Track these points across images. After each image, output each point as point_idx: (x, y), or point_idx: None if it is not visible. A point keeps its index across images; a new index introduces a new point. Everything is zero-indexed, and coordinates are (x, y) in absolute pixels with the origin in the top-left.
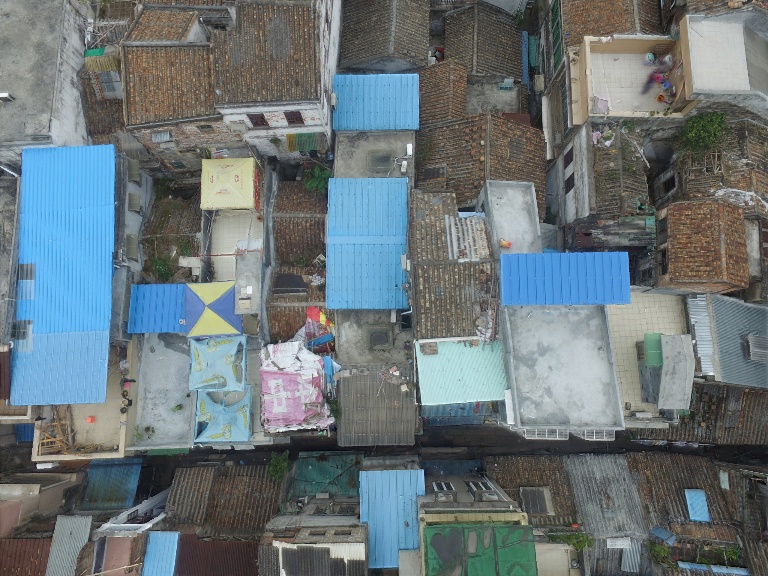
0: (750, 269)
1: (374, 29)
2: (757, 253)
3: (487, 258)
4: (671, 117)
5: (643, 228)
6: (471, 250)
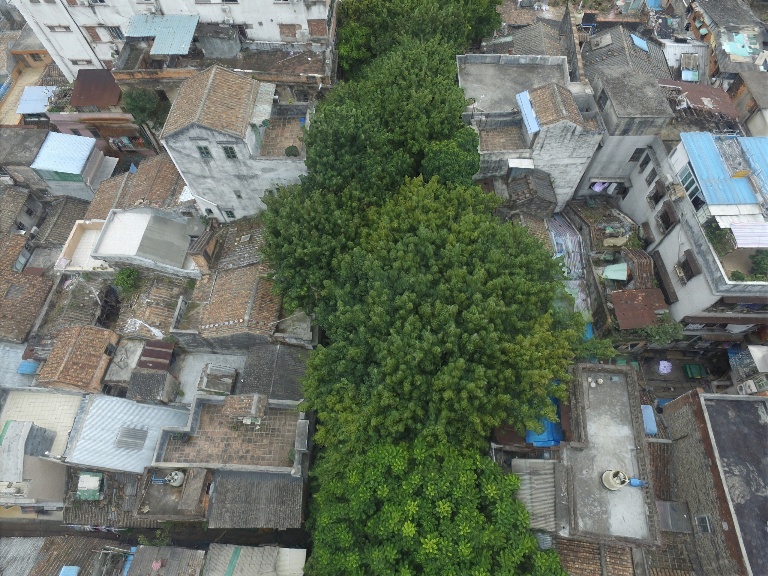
0: (125, 375)
1: None
2: (135, 364)
3: None
4: (108, 271)
5: None
6: None
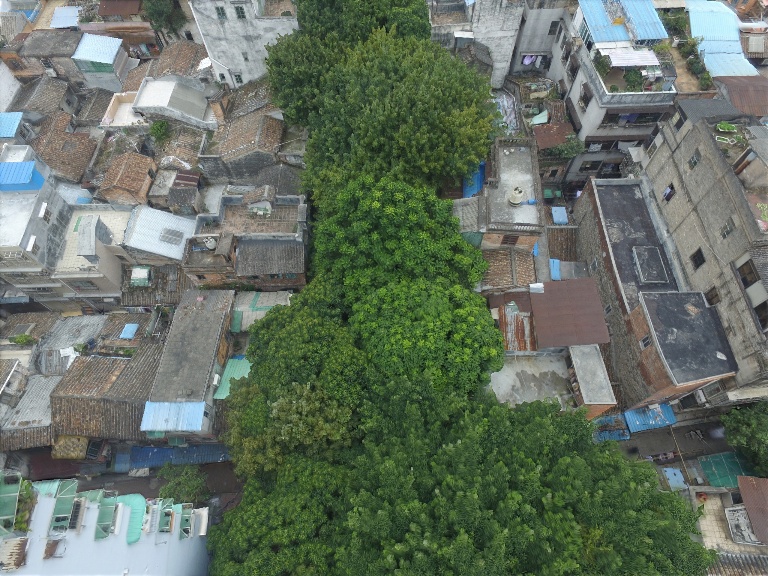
0: (164, 192)
1: (25, 99)
2: (171, 185)
3: None
4: (144, 125)
5: None
6: None
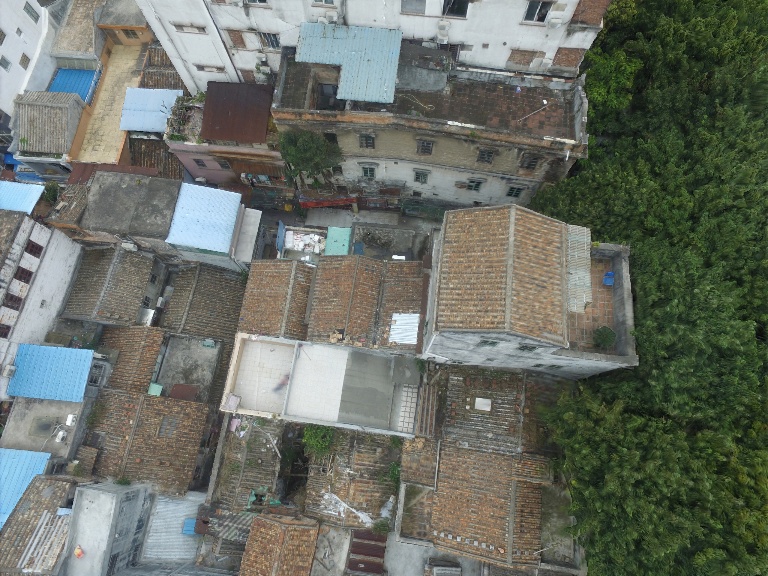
0: None
1: (92, 289)
2: (343, 564)
3: (49, 570)
4: None
5: (249, 525)
6: (40, 559)
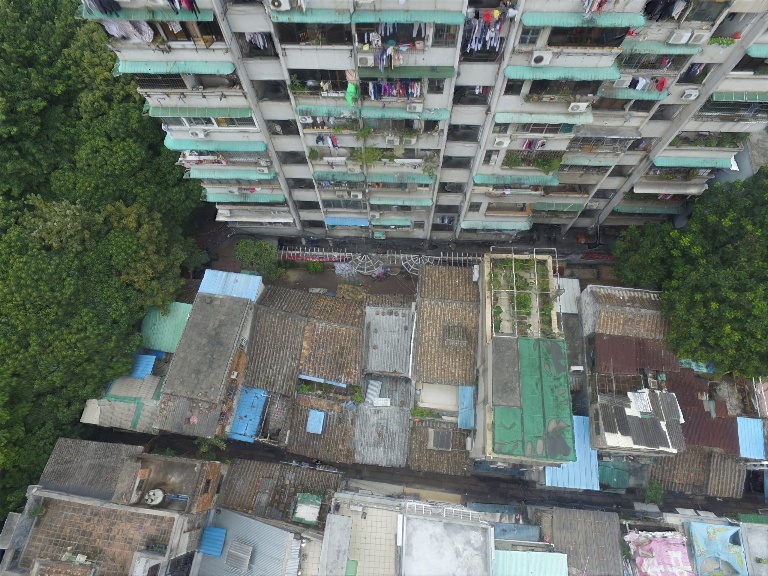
0: None
1: None
2: None
3: None
4: None
5: None
6: None
